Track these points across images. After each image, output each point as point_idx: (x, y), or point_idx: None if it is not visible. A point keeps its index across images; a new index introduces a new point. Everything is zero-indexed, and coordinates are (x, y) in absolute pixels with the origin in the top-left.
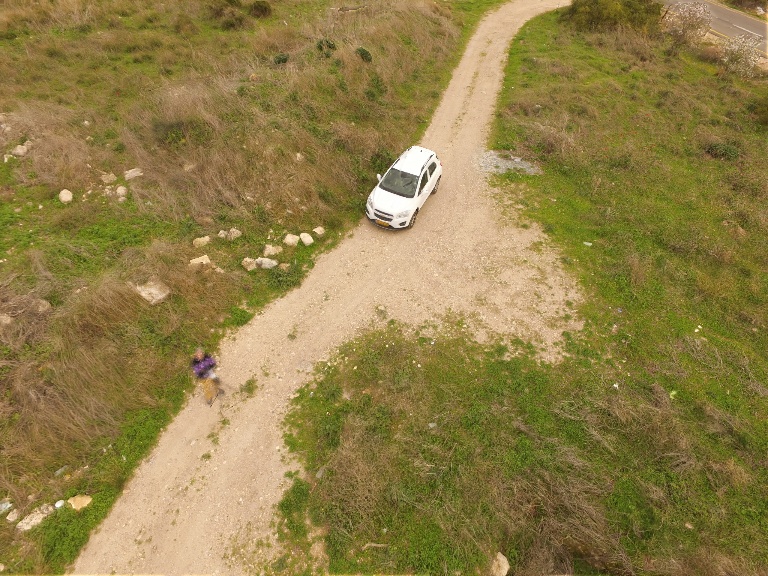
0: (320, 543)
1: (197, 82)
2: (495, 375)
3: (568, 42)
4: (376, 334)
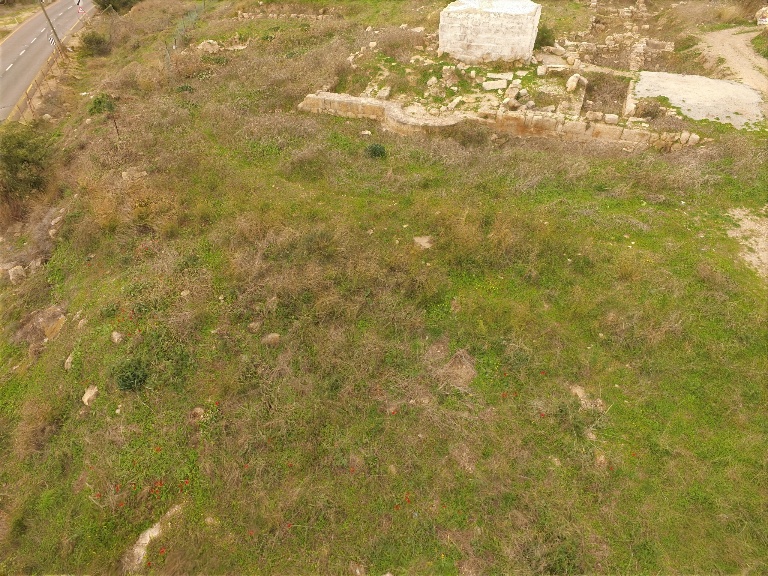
0: None
1: None
2: (767, 194)
3: None
4: None
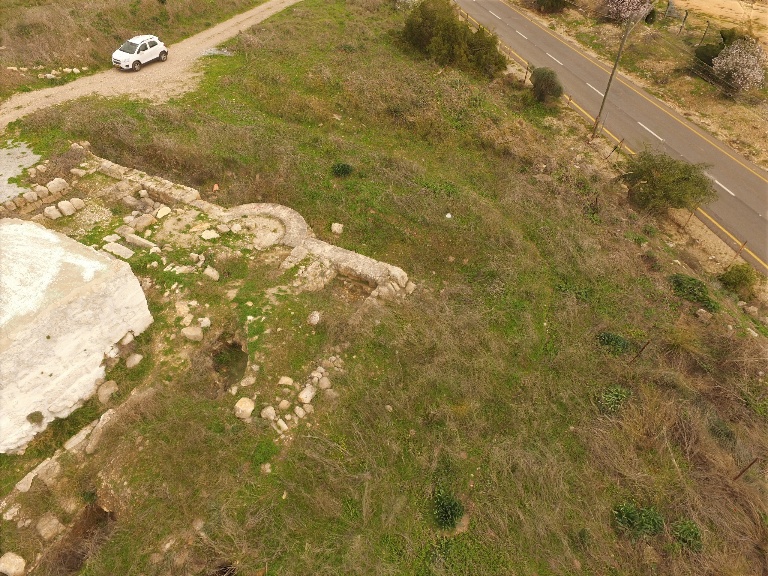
0: (19, 132)
1: (45, 6)
2: None
3: (333, 2)
4: (86, 97)
